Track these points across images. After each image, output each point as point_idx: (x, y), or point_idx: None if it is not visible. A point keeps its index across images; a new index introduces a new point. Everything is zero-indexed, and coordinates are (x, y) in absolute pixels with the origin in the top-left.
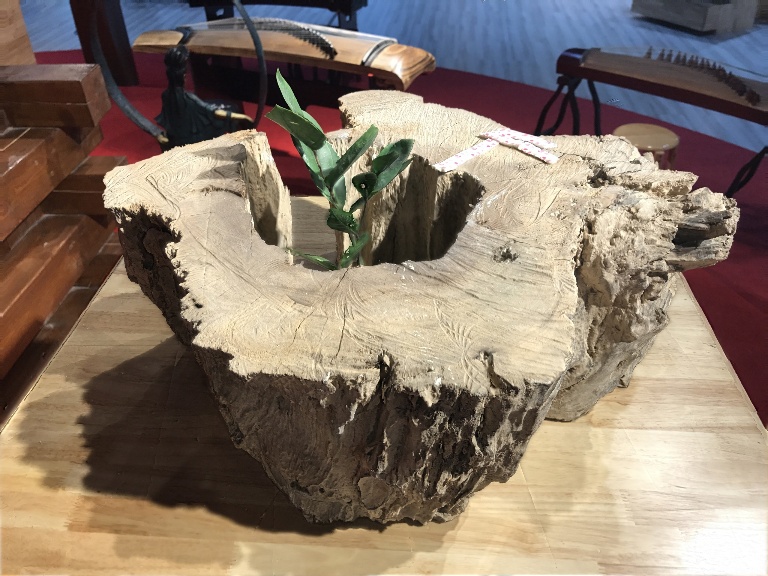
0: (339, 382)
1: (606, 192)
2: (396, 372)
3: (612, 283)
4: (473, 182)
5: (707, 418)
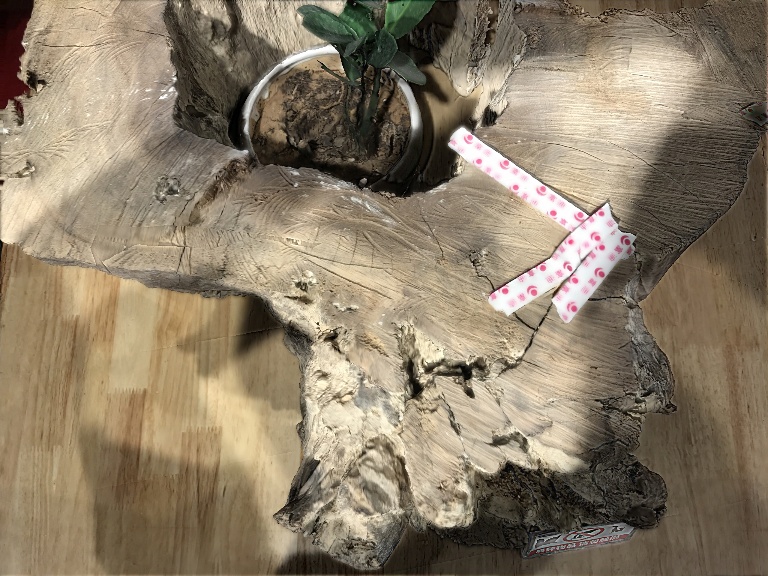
0: None
1: (375, 359)
2: (22, 96)
3: None
4: None
5: (319, 554)
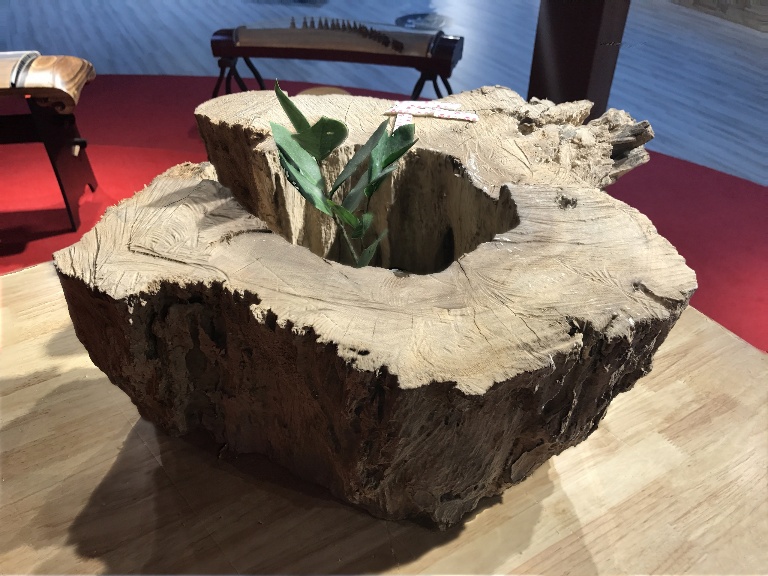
0: (554, 361)
1: (550, 132)
2: (595, 329)
3: None
4: (432, 155)
5: None
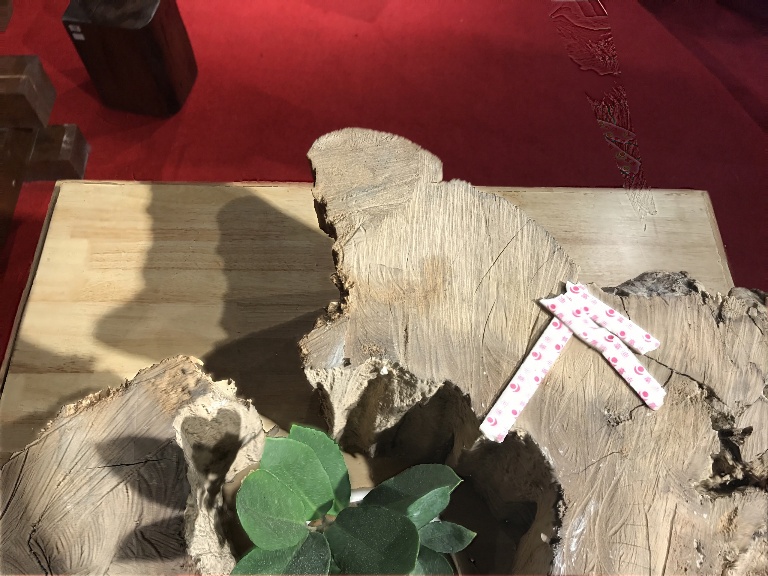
0: None
1: (745, 521)
2: None
3: None
4: (541, 457)
5: None
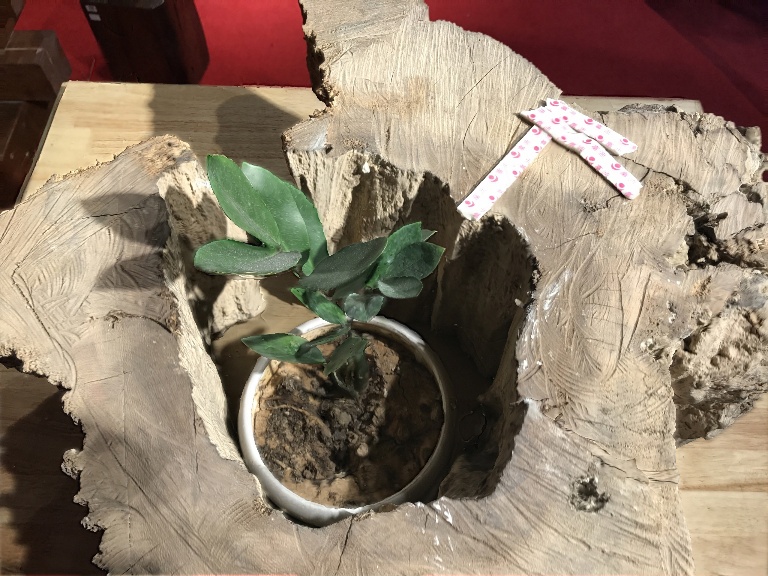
0: None
1: (718, 286)
2: None
3: (699, 399)
4: (517, 238)
5: (758, 470)
